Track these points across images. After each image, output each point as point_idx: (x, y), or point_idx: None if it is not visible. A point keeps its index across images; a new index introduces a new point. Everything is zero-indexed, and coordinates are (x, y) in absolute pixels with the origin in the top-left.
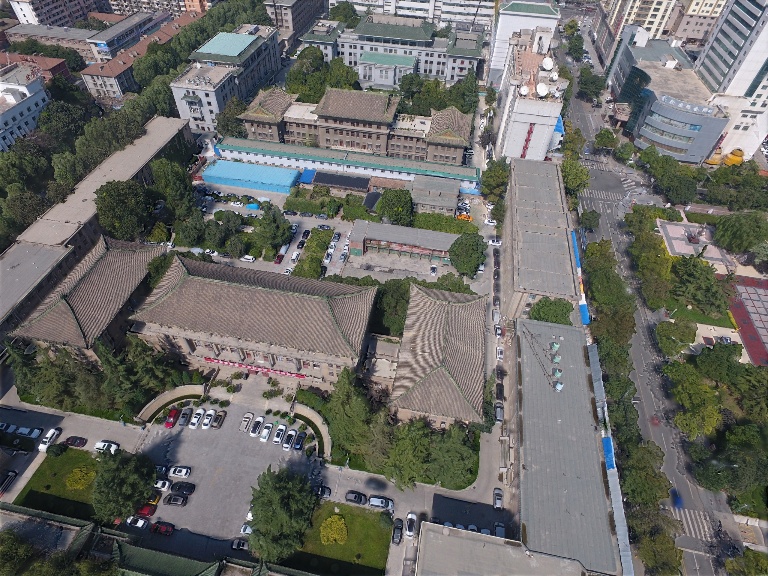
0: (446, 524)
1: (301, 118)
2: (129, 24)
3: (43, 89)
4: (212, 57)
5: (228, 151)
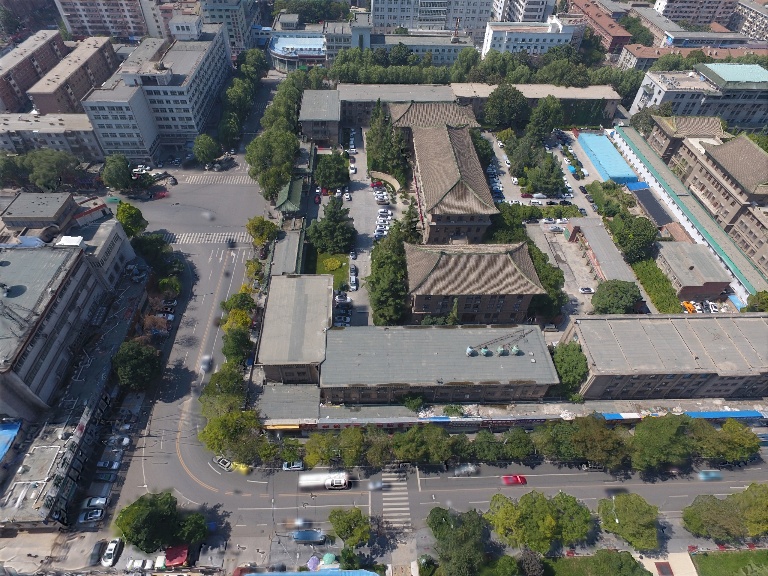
0: (348, 318)
1: (696, 147)
2: (716, 36)
3: (574, 34)
4: (709, 73)
5: (619, 135)
